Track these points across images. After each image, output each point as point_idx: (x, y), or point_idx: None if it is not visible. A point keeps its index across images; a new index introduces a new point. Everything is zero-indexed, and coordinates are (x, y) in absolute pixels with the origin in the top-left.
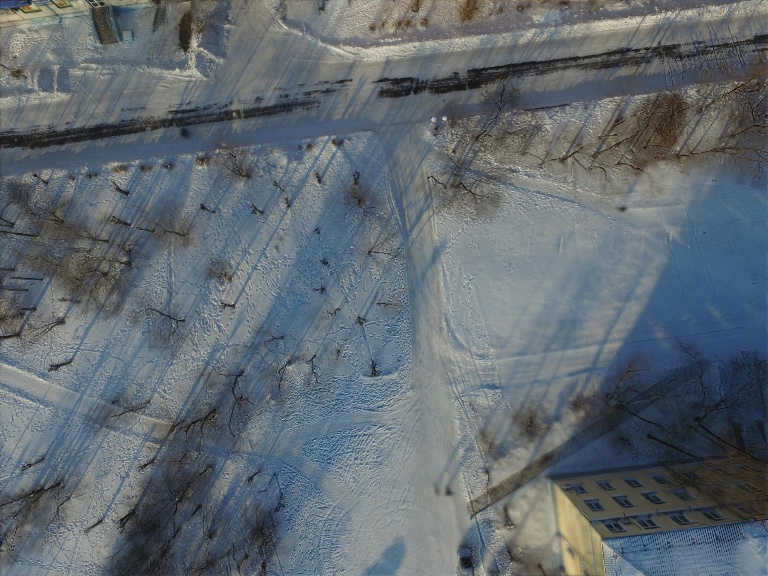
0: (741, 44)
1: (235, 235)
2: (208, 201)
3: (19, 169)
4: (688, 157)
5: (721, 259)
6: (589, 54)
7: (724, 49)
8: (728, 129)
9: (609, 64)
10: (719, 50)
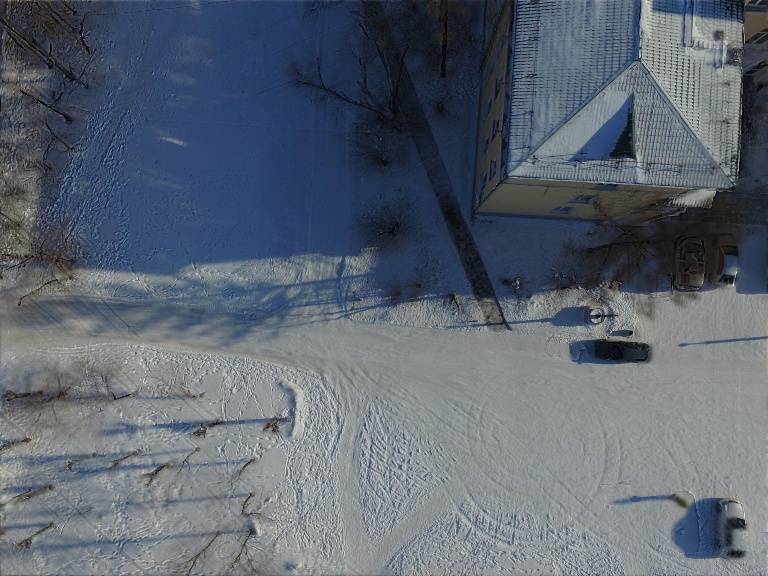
0: None
1: (72, 568)
2: None
3: None
4: None
5: None
6: None
7: None
8: None
9: None
10: None
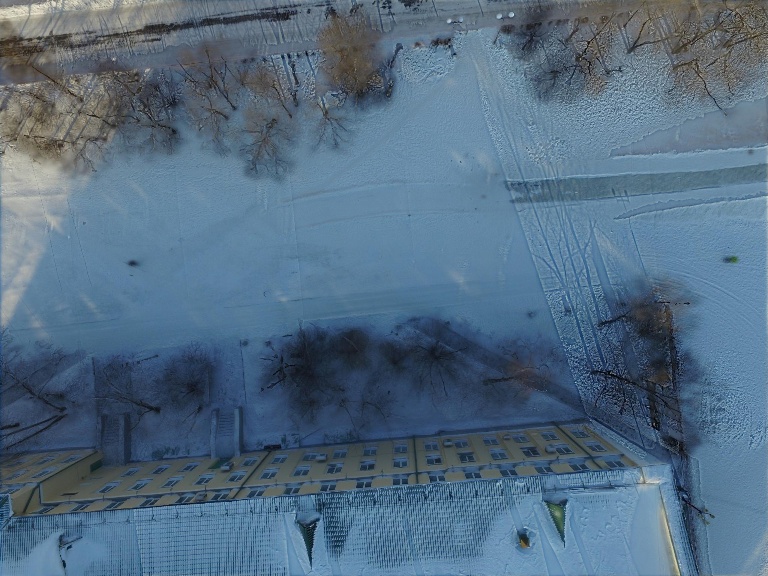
0: (131, 34)
1: None
2: None
3: None
4: (70, 147)
5: (100, 250)
6: None
7: (114, 39)
8: (108, 119)
9: (2, 53)
10: (109, 40)
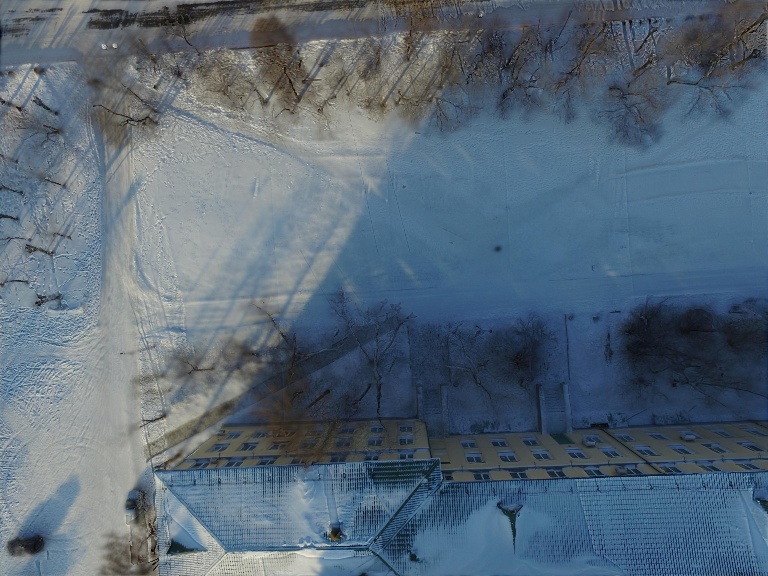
0: None
1: None
2: None
3: None
4: (392, 107)
5: (419, 215)
6: None
7: None
8: (435, 80)
9: (321, 7)
10: None
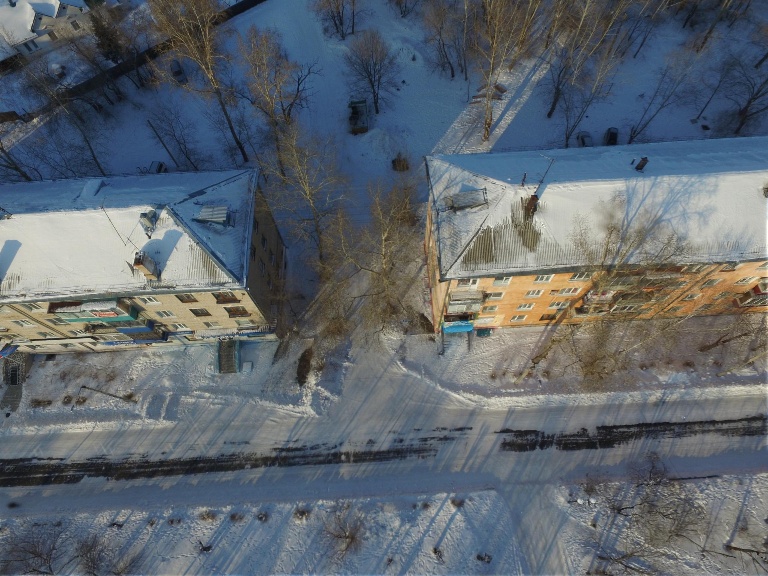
0: None
1: None
2: (301, 567)
3: (96, 504)
4: None
5: None
6: (727, 419)
7: None
8: None
9: (752, 431)
10: None
